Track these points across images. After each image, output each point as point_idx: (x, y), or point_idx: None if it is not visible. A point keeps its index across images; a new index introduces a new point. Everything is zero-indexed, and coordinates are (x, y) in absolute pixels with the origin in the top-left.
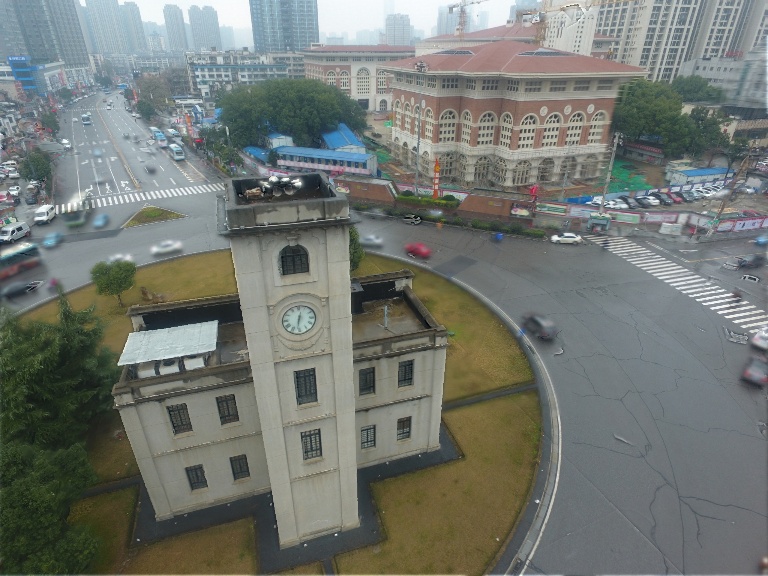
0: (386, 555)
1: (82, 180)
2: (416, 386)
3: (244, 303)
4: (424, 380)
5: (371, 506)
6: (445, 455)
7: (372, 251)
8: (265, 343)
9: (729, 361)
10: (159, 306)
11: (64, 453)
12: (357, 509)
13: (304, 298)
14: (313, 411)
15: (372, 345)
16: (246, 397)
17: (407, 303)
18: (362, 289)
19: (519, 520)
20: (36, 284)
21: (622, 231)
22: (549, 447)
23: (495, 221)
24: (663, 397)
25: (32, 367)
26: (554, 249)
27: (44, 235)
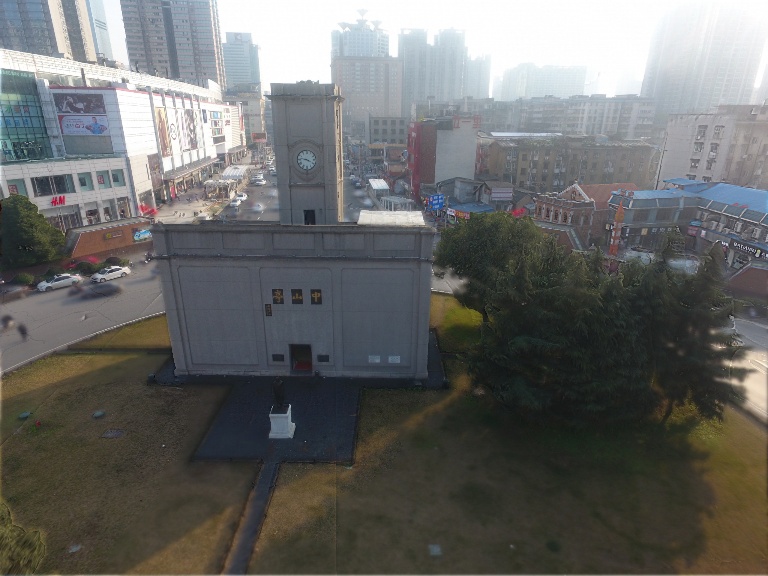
0: None
1: None
2: None
3: None
4: None
5: None
6: None
7: None
8: None
9: None
10: None
11: None
12: None
13: None
14: None
15: None
16: None
17: None
18: None
19: None
20: None
21: None
22: None
23: None
24: None
25: None
26: None
27: None
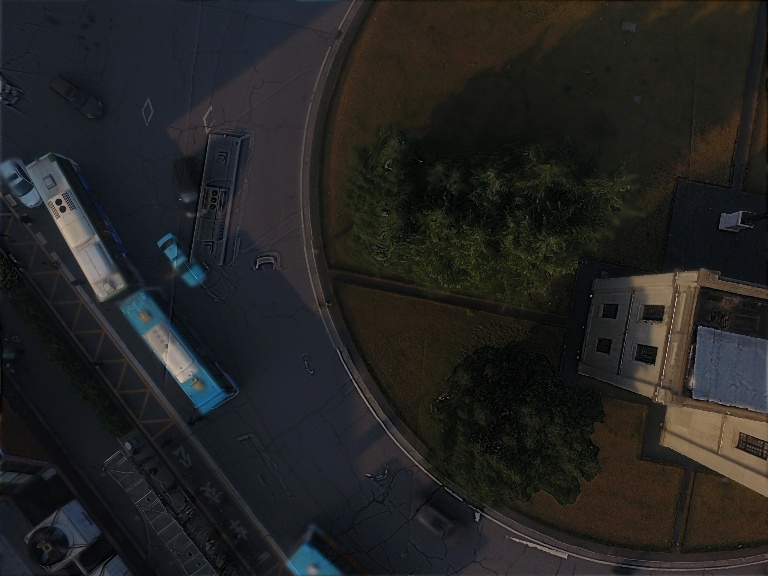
0: (731, 489)
1: None
2: None
3: None
4: None
5: None
6: None
7: None
8: None
9: None
10: (738, 288)
11: None
12: None
13: None
14: None
15: None
16: None
17: None
18: None
19: None
20: None
21: None
22: None
23: None
24: None
25: (566, 271)
26: None
27: None
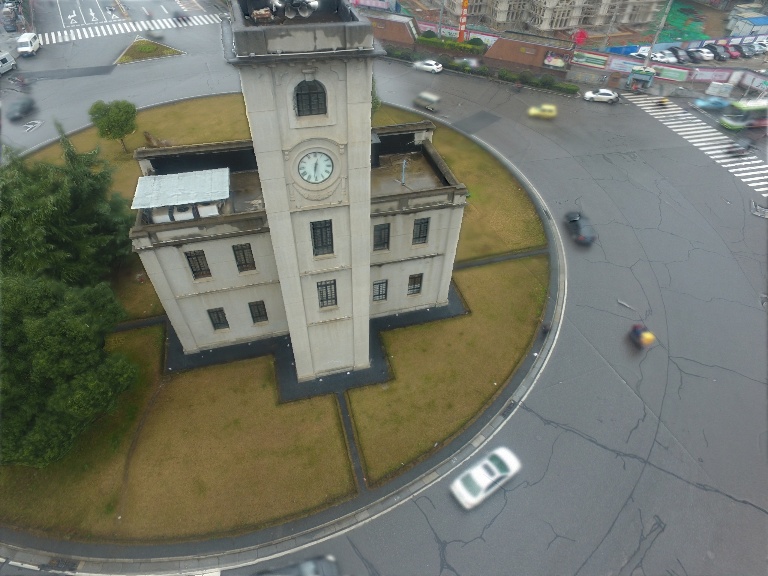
0: (393, 391)
1: (62, 4)
2: (430, 244)
3: (258, 146)
4: (438, 239)
5: (381, 351)
6: (452, 310)
7: (388, 102)
8: (281, 191)
9: (748, 235)
10: (166, 150)
11: (91, 291)
12: (368, 353)
13: (321, 144)
14: (329, 262)
15: (388, 200)
16: (262, 247)
17: (426, 158)
18: (379, 141)
19: (517, 369)
20: (34, 124)
21: (664, 90)
22: (553, 308)
23: (525, 72)
24: (673, 267)
25: (46, 208)
26: (586, 108)
27: (32, 69)
